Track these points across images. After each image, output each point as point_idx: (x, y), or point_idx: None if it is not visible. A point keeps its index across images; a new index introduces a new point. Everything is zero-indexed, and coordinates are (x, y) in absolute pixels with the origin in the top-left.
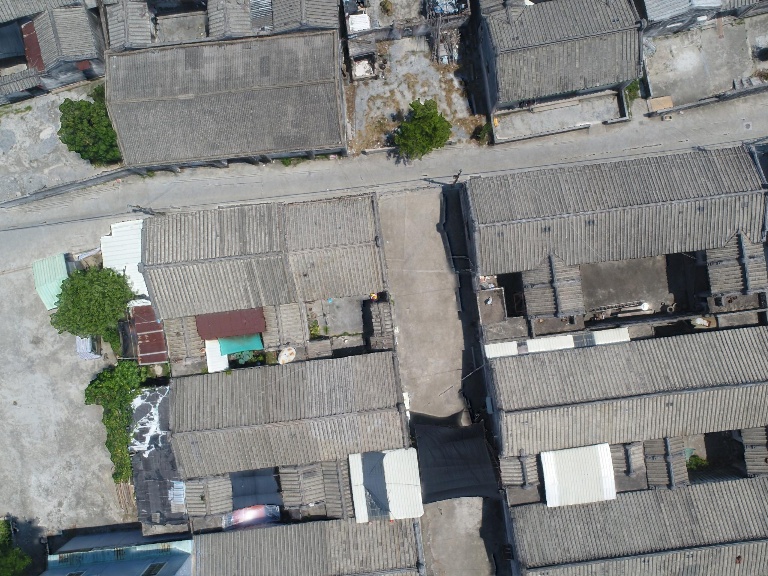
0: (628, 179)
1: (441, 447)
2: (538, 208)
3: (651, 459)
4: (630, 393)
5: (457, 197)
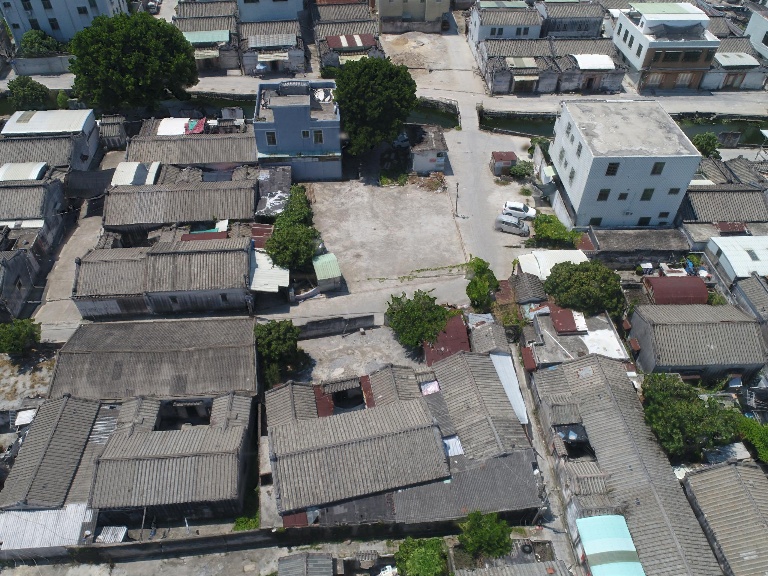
0: None
1: None
2: None
3: None
4: None
5: None
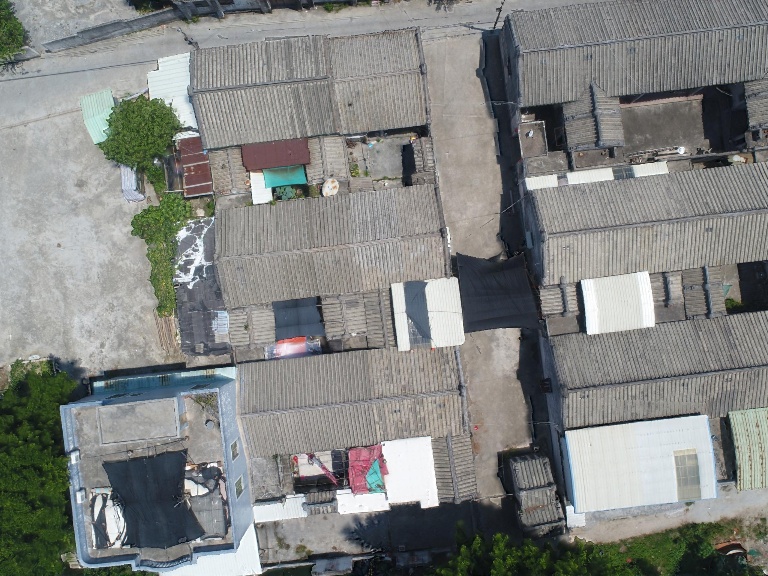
0: (668, 10)
1: (482, 278)
2: (580, 36)
3: (689, 289)
4: (670, 217)
5: (496, 43)
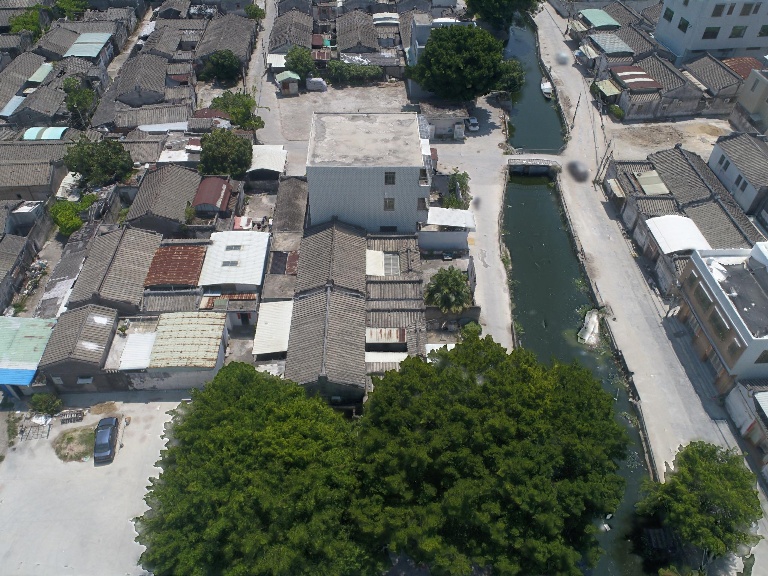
0: None
1: (374, 13)
2: None
3: None
4: None
5: None
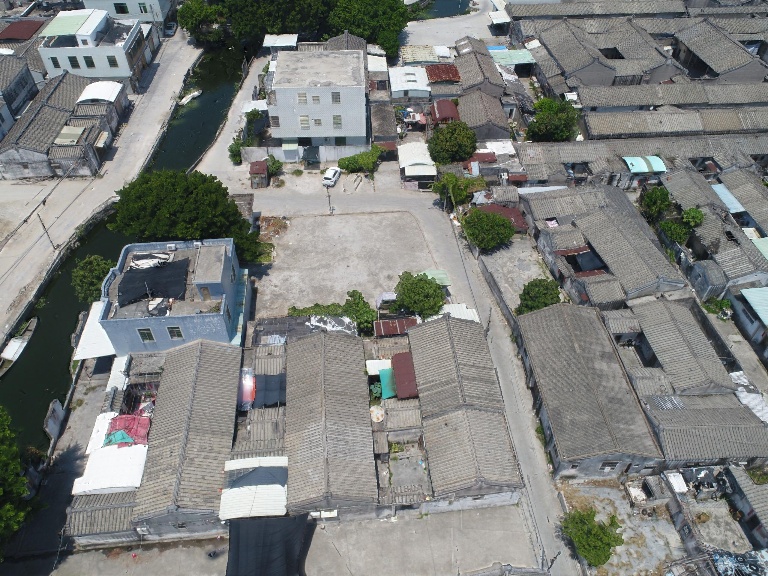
0: None
1: (282, 543)
2: None
3: None
4: None
5: None
